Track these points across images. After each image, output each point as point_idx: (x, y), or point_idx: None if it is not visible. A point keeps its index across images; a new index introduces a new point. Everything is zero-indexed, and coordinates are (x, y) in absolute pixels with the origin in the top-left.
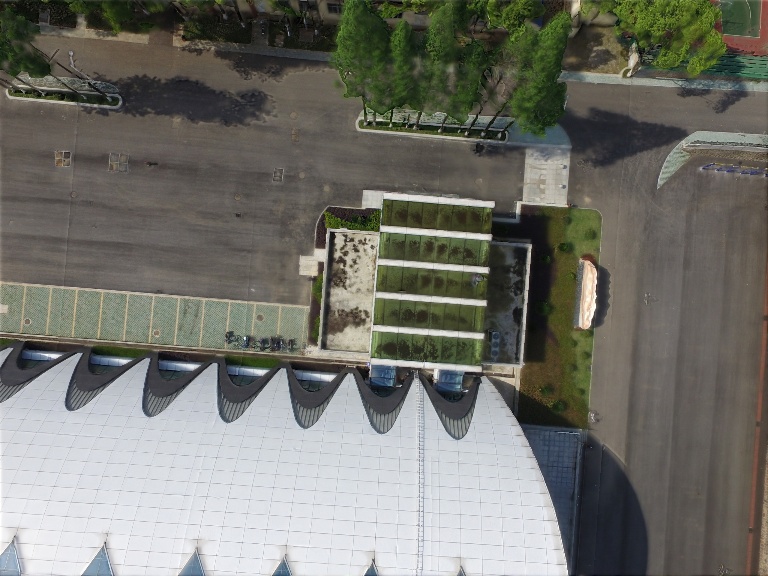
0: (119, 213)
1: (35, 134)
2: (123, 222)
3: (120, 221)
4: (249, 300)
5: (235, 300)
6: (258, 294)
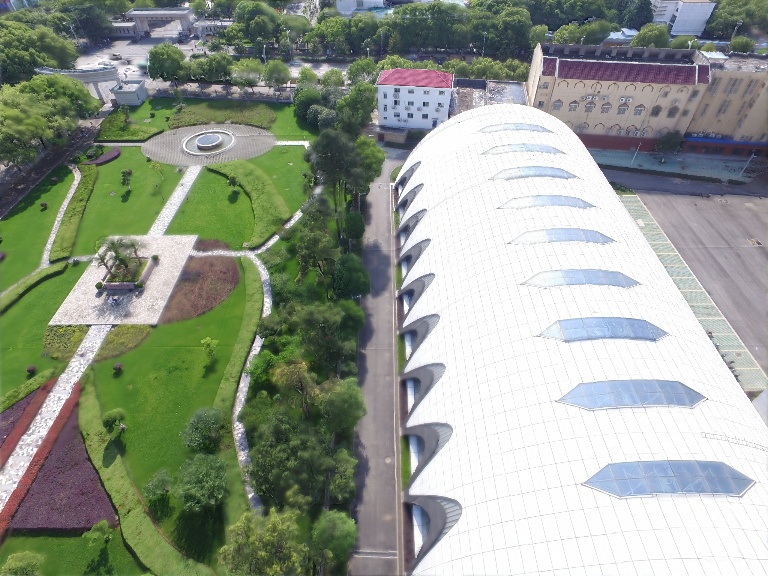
0: (745, 269)
1: (758, 230)
2: (741, 272)
3: (740, 270)
4: (747, 346)
5: (739, 337)
6: (756, 352)
